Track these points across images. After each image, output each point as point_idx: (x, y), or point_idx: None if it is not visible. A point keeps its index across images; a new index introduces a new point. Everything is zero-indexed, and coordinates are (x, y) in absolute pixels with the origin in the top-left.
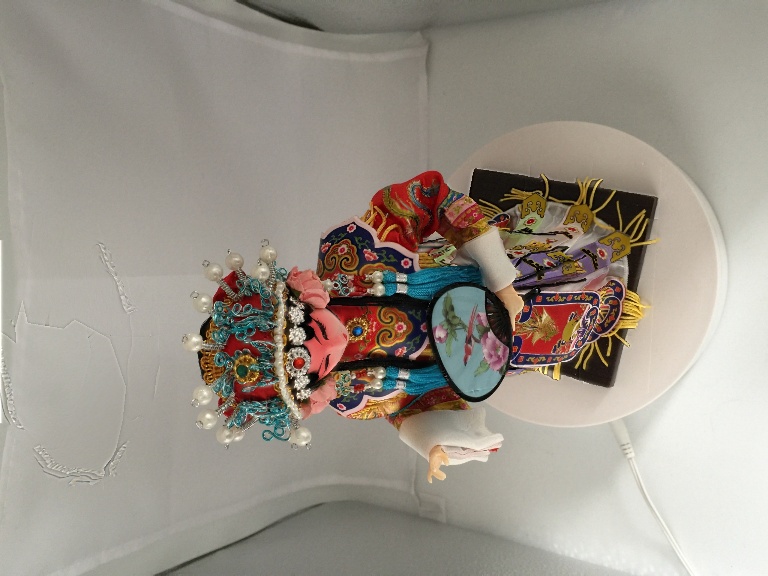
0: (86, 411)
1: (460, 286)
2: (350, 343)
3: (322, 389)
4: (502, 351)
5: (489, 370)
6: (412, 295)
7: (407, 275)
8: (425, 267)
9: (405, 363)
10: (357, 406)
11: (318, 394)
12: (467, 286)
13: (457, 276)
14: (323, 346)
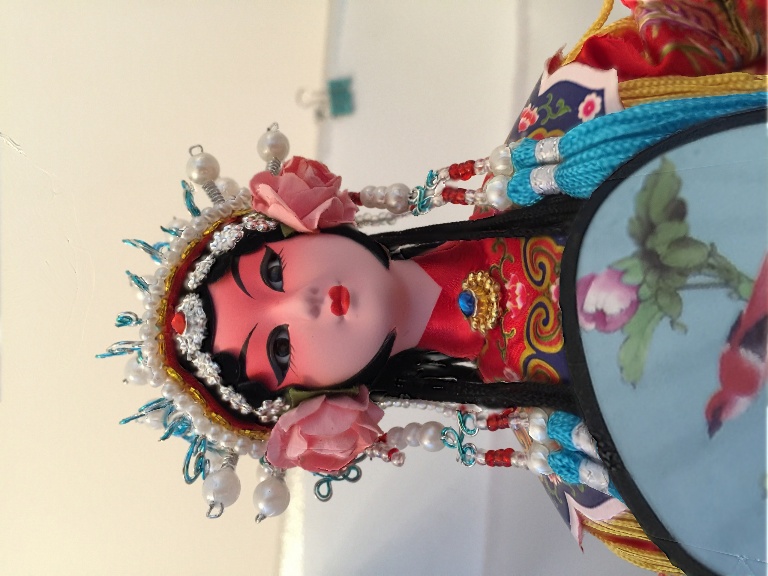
0: (44, 355)
1: (732, 126)
2: None
3: (301, 406)
4: None
5: None
6: (570, 191)
7: None
8: None
9: None
10: (570, 522)
11: (293, 414)
12: None
13: None
14: (255, 301)
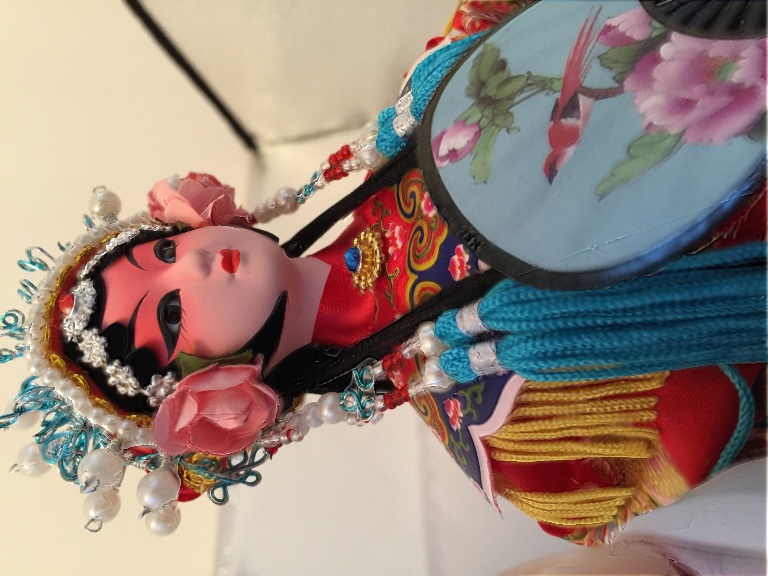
0: None
1: (529, 8)
2: (377, 299)
3: (191, 373)
4: (756, 63)
5: (683, 153)
6: None
7: None
8: None
9: (469, 286)
10: (480, 469)
11: None
12: None
13: None
14: (147, 272)
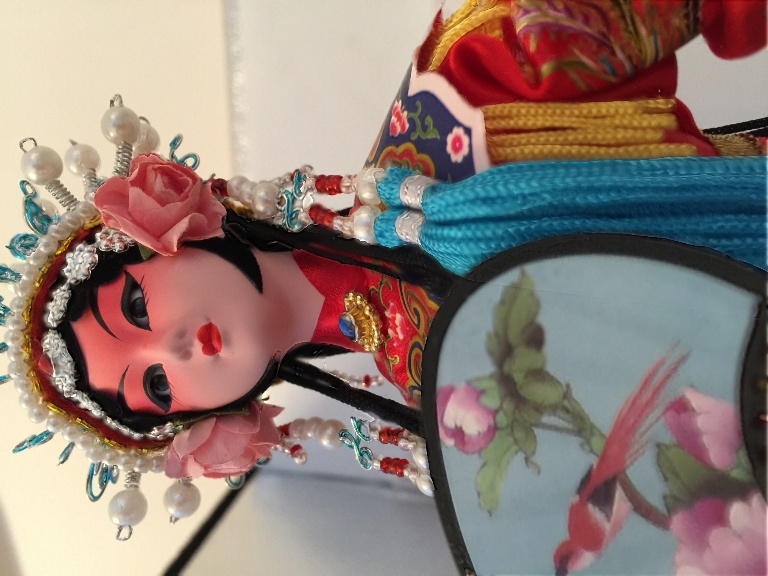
0: None
1: (595, 251)
2: None
3: (192, 431)
4: None
5: None
6: None
7: (426, 186)
8: (571, 158)
9: None
10: None
11: (186, 438)
12: (638, 255)
13: (698, 202)
14: (122, 342)
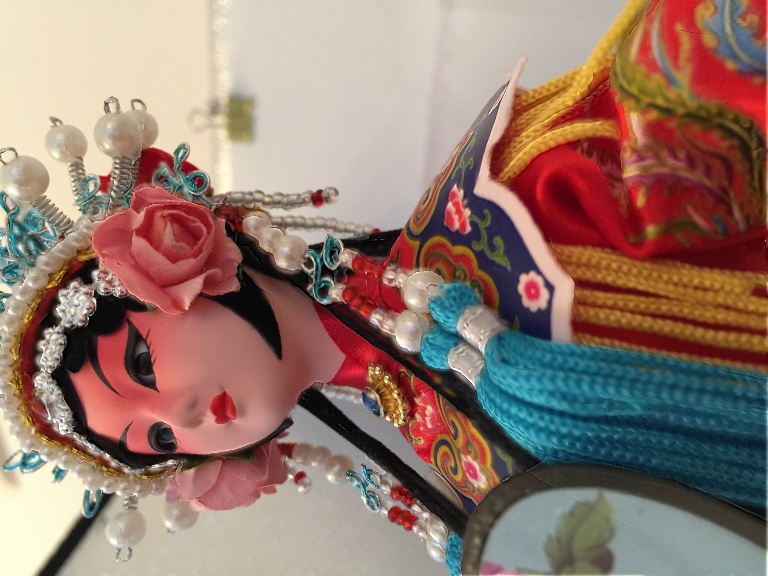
0: None
1: (690, 509)
2: None
3: (196, 473)
4: None
5: None
6: None
7: (492, 335)
8: (662, 335)
9: None
10: None
11: (190, 476)
12: (739, 532)
13: None
14: (125, 399)
